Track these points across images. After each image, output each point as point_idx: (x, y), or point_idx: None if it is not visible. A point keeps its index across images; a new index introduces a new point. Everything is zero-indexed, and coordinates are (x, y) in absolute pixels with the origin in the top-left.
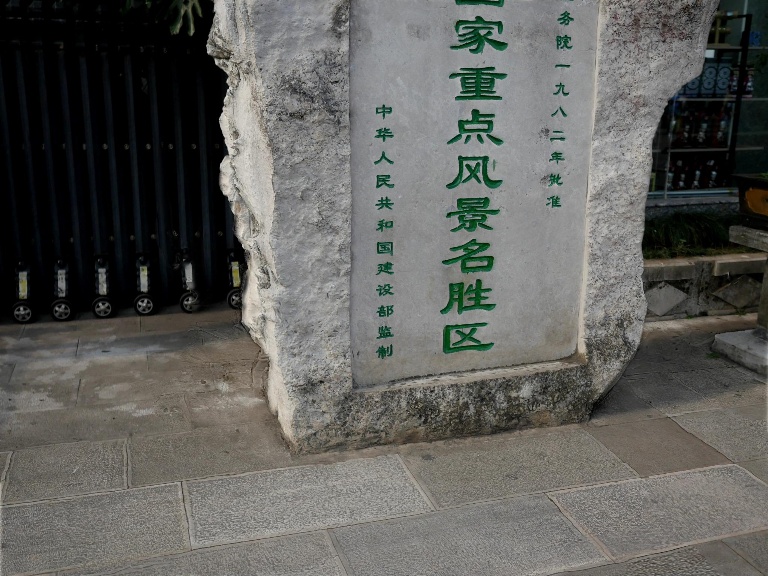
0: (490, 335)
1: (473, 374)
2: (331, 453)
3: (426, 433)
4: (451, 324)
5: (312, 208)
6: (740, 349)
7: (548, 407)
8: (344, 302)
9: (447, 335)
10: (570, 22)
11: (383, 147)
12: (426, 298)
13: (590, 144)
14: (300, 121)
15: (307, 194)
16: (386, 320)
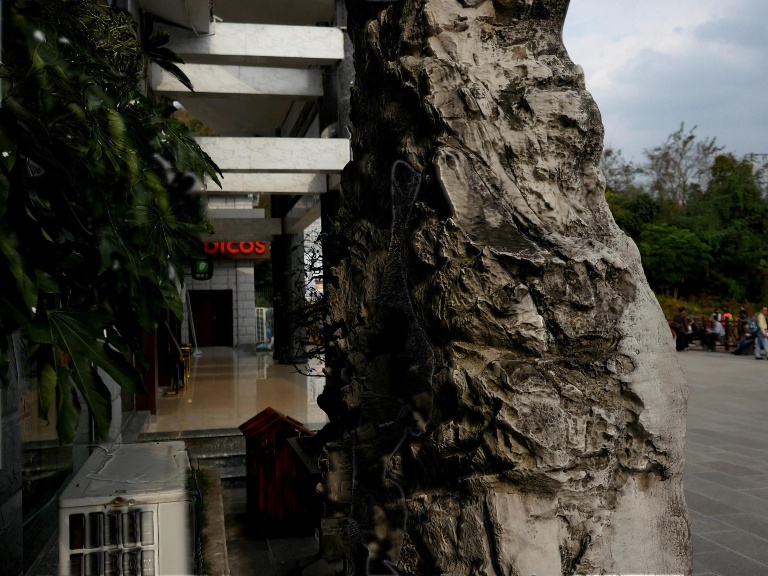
0: None
1: None
2: None
3: None
4: None
5: None
6: None
7: None
8: None
9: None
10: None
11: None
12: None
13: None
14: None
15: None
16: None
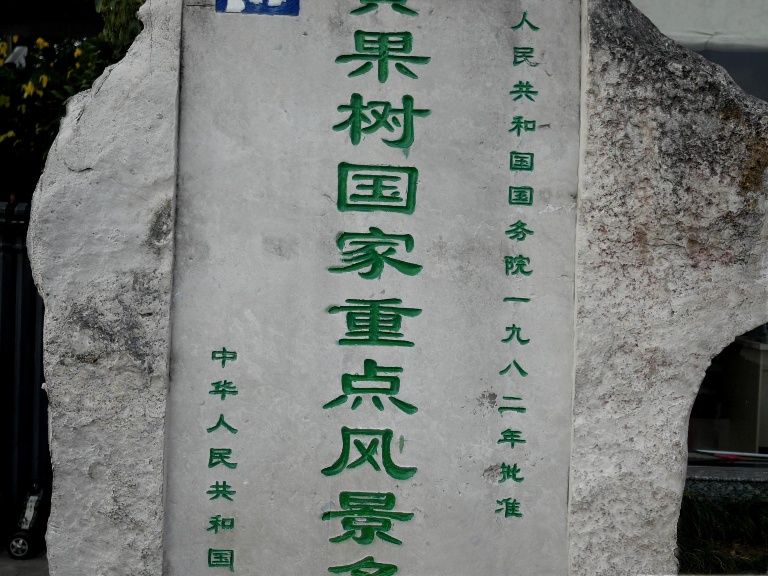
0: None
1: None
2: None
3: None
4: None
5: (106, 491)
6: None
7: None
8: None
9: None
10: (527, 236)
11: (222, 408)
12: None
13: (570, 420)
14: (92, 366)
15: (98, 470)
16: None
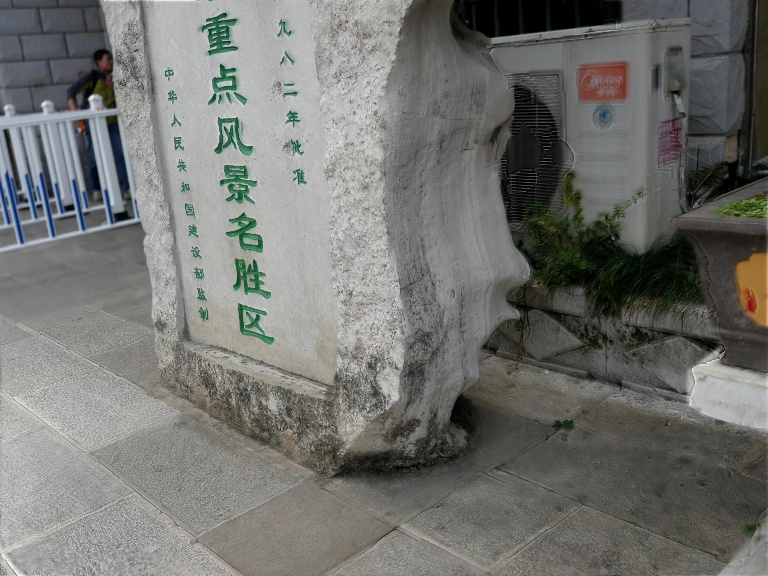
0: (270, 328)
1: (253, 365)
2: (166, 390)
3: (210, 406)
4: (242, 303)
5: None
6: (760, 537)
7: (294, 435)
8: (170, 256)
9: (242, 314)
10: None
11: (174, 109)
12: (222, 269)
13: None
14: (126, 88)
15: (139, 153)
16: (201, 282)
